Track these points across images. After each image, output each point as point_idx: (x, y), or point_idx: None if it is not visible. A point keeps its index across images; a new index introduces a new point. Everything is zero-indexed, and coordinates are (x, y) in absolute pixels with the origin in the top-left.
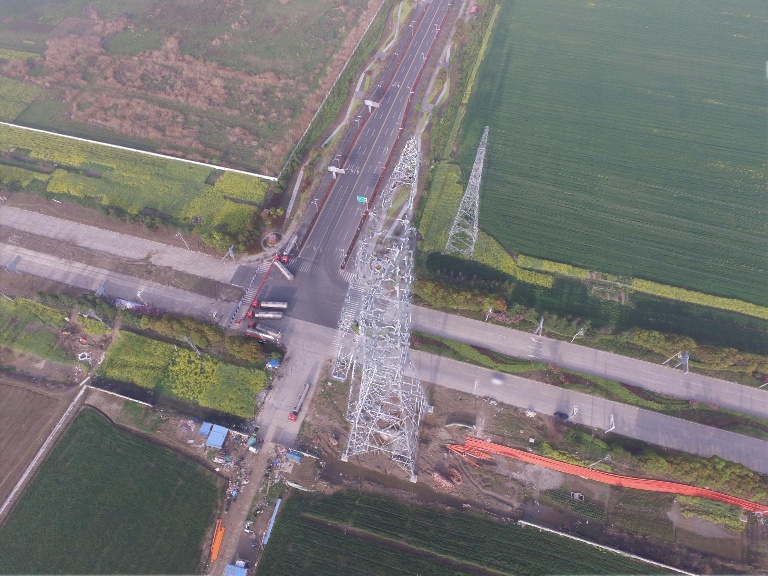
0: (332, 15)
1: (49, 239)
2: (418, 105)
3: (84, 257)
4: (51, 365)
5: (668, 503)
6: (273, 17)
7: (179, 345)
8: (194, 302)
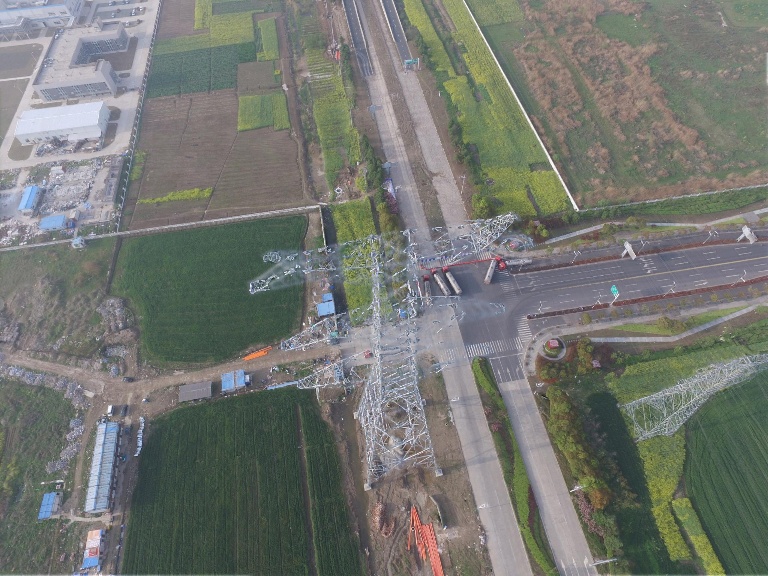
0: None
1: (408, 112)
2: None
3: (408, 139)
4: (323, 178)
5: None
6: None
7: None
8: (419, 227)
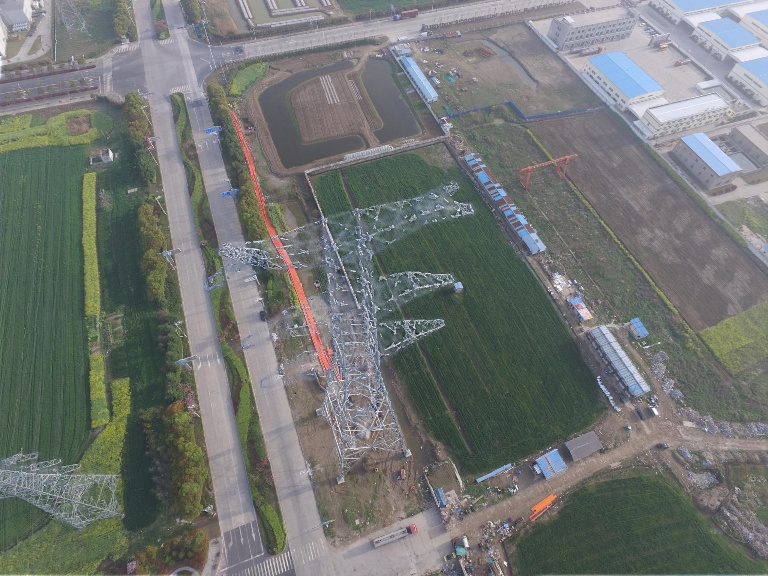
0: None
1: None
2: None
3: None
4: None
5: None
6: None
7: None
8: None
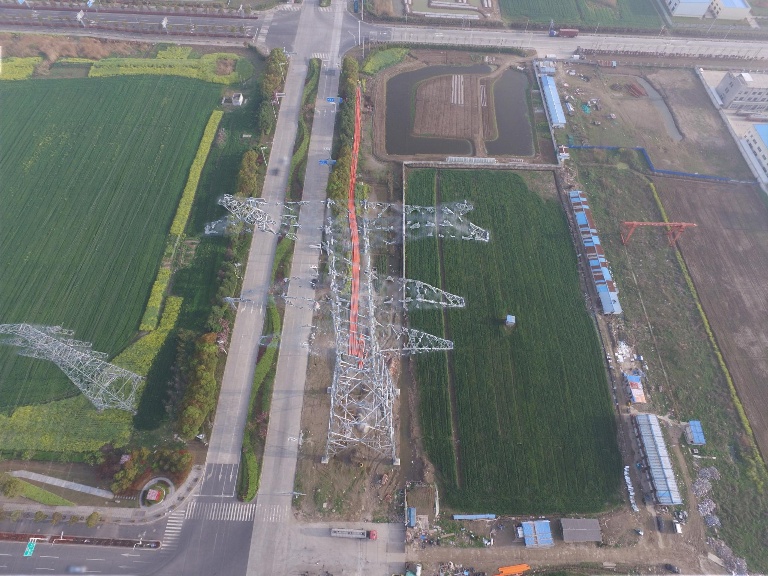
0: None
1: None
2: None
3: None
4: None
5: None
6: None
7: None
8: None
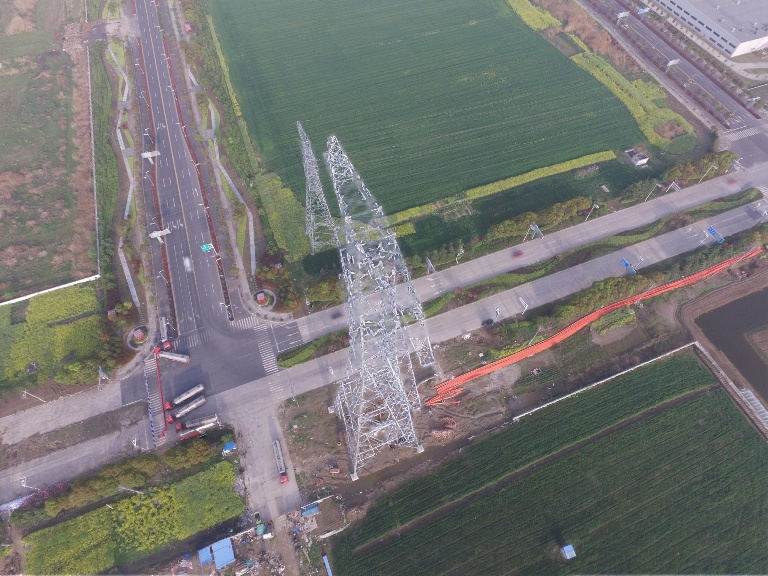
0: (37, 85)
1: None
2: (198, 136)
3: None
4: None
5: (588, 334)
6: None
7: (111, 502)
8: (95, 449)
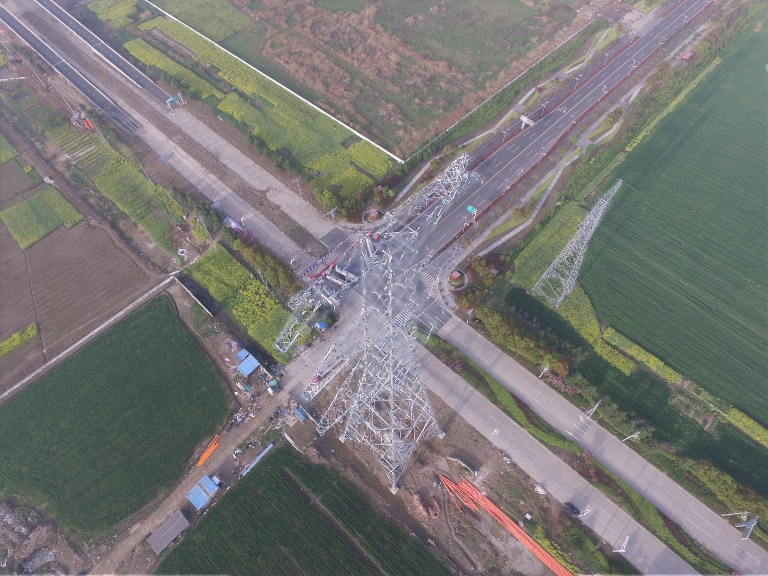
0: (531, 23)
1: (201, 147)
2: (574, 137)
3: (219, 172)
4: (158, 249)
5: None
6: (472, 10)
7: (255, 275)
8: (284, 244)
